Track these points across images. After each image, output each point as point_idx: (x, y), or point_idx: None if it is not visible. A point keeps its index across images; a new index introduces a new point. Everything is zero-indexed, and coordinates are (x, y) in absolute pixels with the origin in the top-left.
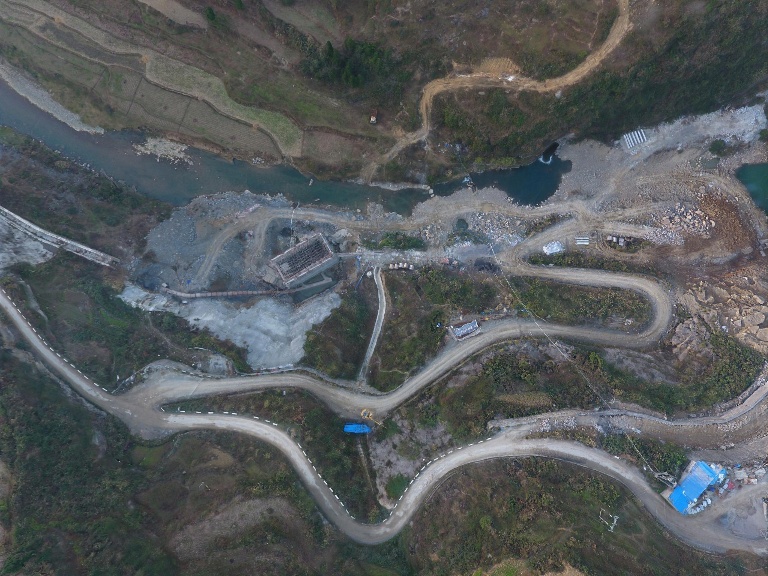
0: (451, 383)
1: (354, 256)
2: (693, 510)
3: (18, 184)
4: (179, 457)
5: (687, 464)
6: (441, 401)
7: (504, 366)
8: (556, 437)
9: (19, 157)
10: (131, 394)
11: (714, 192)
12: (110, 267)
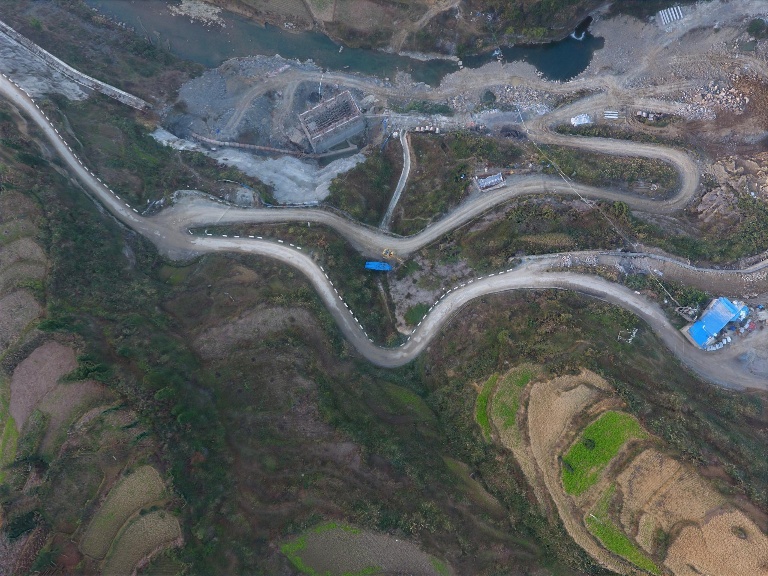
0: (473, 229)
1: (381, 120)
2: (712, 347)
3: (57, 32)
4: (205, 273)
5: (708, 303)
6: (463, 242)
7: (527, 213)
8: (577, 270)
9: (58, 10)
10: (160, 216)
11: (749, 74)
12: (143, 111)
